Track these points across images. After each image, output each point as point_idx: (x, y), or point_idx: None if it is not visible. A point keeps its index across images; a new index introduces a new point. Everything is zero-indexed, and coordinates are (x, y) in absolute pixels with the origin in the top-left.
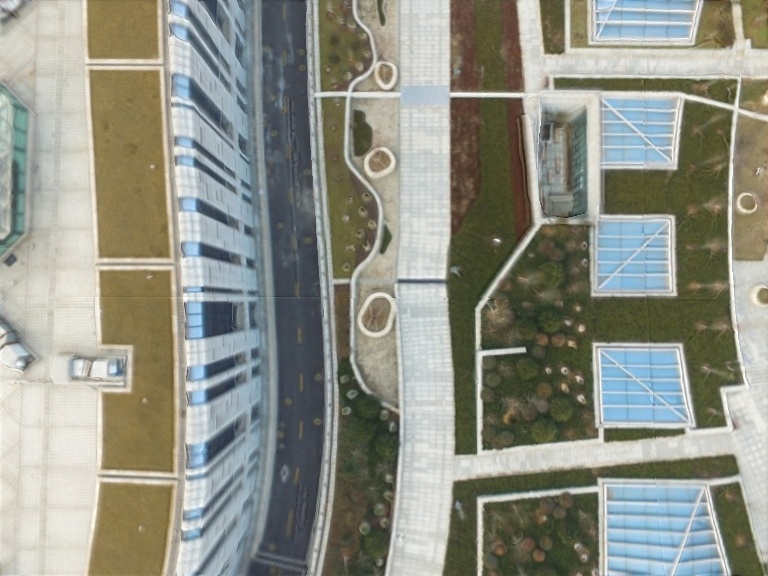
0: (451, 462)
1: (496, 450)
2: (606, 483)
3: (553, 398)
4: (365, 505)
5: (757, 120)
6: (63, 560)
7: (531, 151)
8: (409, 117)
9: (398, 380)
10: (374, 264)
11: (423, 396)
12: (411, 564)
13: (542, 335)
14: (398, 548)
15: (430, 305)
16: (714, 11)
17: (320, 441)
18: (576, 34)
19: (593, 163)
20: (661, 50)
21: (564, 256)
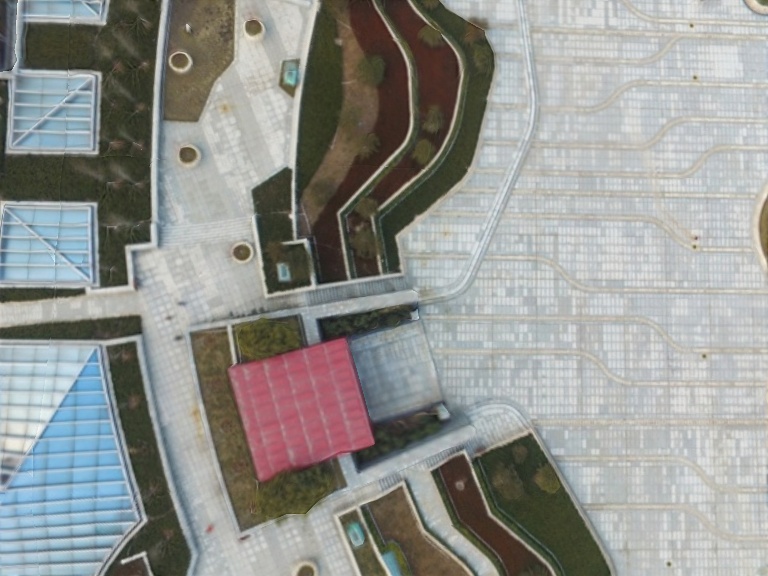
0: None
1: None
2: None
3: None
4: None
5: None
6: None
7: None
8: None
9: None
10: None
11: None
12: None
13: None
14: None
15: None
16: None
17: None
18: None
19: (17, 16)
20: None
21: None
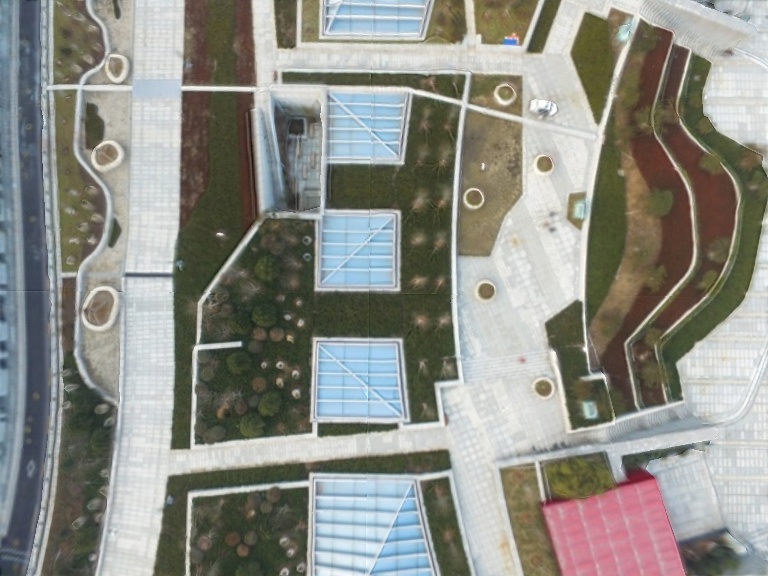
0: (167, 457)
1: (208, 444)
2: (316, 478)
3: (265, 392)
4: (82, 500)
5: (488, 115)
6: None
7: (258, 145)
8: (141, 110)
9: None
10: (103, 258)
11: (143, 390)
12: (123, 559)
13: (260, 329)
14: (110, 543)
15: (156, 299)
16: (443, 6)
17: None
18: (307, 28)
19: None
20: (392, 45)
21: (282, 250)
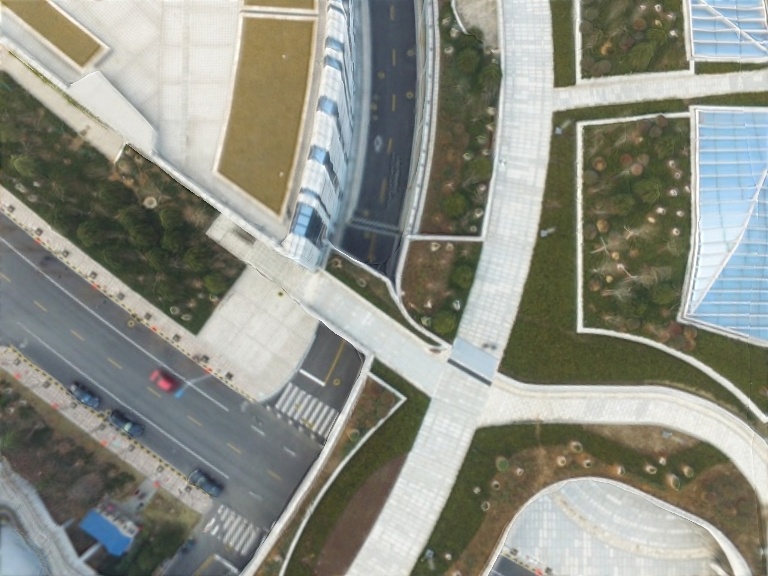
0: (550, 94)
1: (594, 79)
2: (698, 109)
3: (648, 29)
4: (467, 137)
5: None
6: (206, 94)
7: None
8: None
9: (498, 22)
10: None
11: (522, 36)
12: (513, 188)
13: None
14: (501, 172)
15: None
16: None
17: (412, 114)
18: None
19: None
20: None
21: None
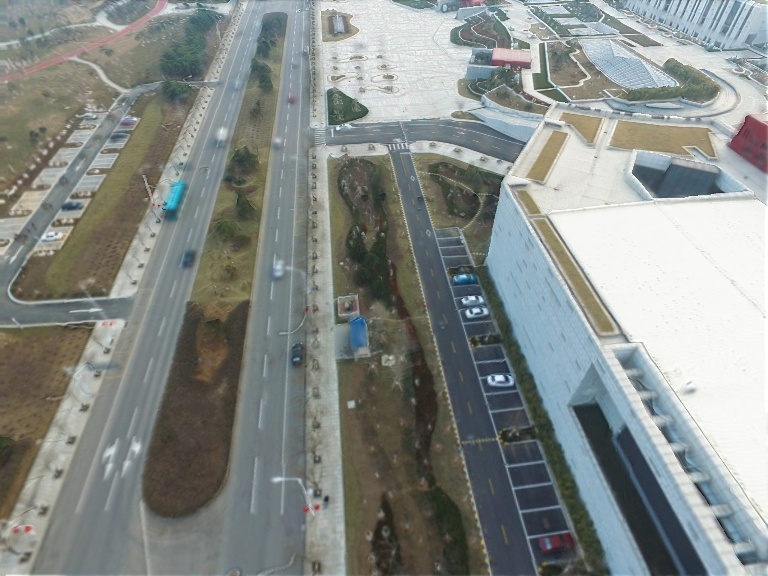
0: (593, 3)
1: None
2: (555, 1)
3: (577, 6)
4: None
5: None
6: None
7: None
8: None
9: None
10: None
11: None
12: None
13: None
14: None
15: (617, 16)
16: None
17: None
18: None
19: None
20: None
21: None
